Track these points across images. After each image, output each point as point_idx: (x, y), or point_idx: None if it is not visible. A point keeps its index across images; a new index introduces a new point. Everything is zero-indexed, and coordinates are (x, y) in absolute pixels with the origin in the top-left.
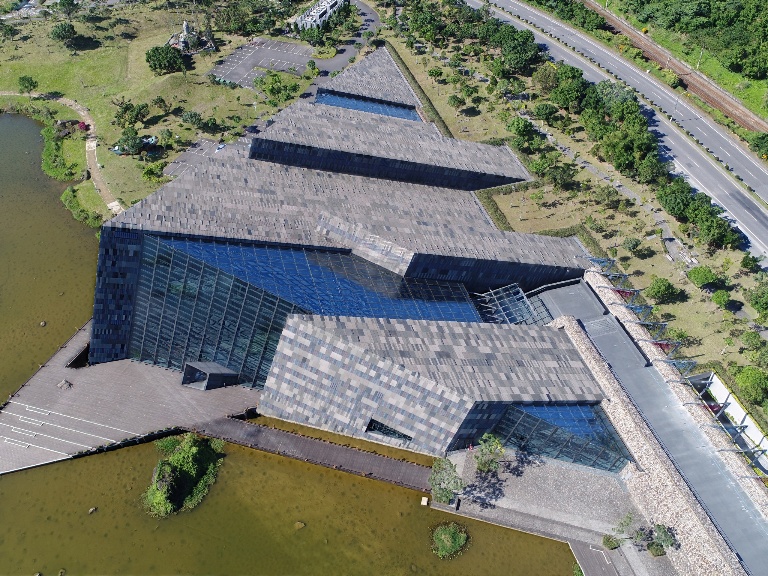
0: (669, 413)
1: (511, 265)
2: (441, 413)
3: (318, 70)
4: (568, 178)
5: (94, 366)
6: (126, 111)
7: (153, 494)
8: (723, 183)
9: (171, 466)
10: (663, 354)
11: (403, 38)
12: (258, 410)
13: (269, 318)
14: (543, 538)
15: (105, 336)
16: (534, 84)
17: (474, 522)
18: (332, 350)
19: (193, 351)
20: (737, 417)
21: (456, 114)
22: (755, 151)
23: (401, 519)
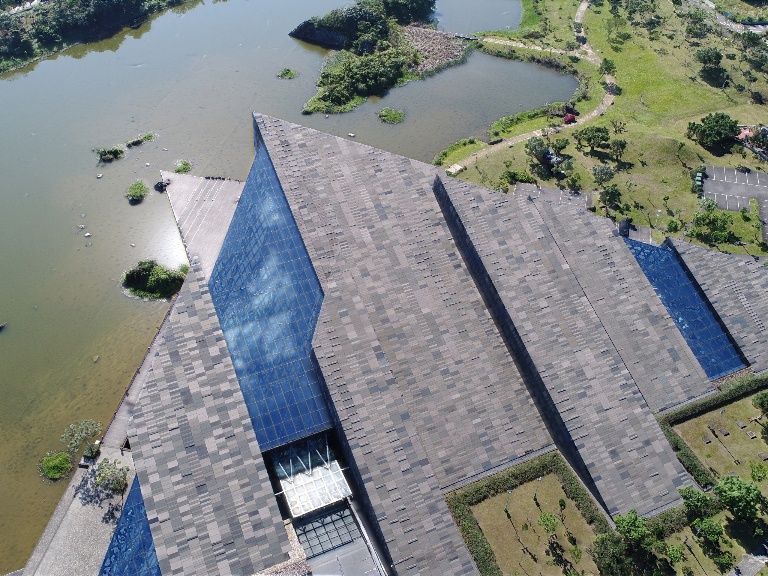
0: None
1: None
2: None
3: None
4: None
5: None
6: (598, 132)
7: None
8: None
9: (149, 267)
10: None
11: None
12: None
13: None
14: None
15: None
16: None
17: None
18: None
19: None
20: None
21: (757, 417)
22: None
23: None
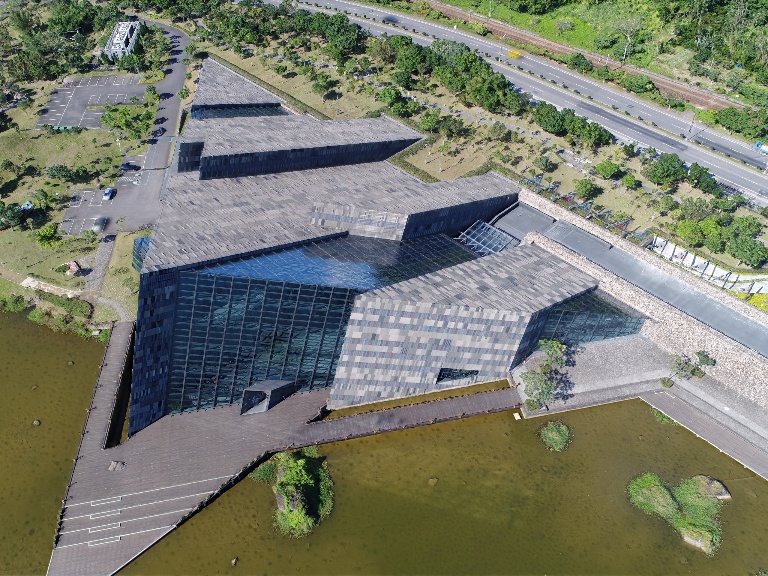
0: (648, 275)
1: (472, 205)
2: (504, 337)
3: (157, 94)
4: (459, 126)
5: (134, 436)
6: None
7: (285, 519)
8: (568, 99)
9: (292, 485)
10: (616, 235)
11: (222, 46)
12: (328, 407)
13: (324, 312)
14: (619, 402)
15: (143, 398)
16: (375, 58)
17: (564, 414)
18: (401, 316)
19: (242, 377)
20: (687, 262)
21: (322, 100)
22: (574, 69)
23: (509, 438)
